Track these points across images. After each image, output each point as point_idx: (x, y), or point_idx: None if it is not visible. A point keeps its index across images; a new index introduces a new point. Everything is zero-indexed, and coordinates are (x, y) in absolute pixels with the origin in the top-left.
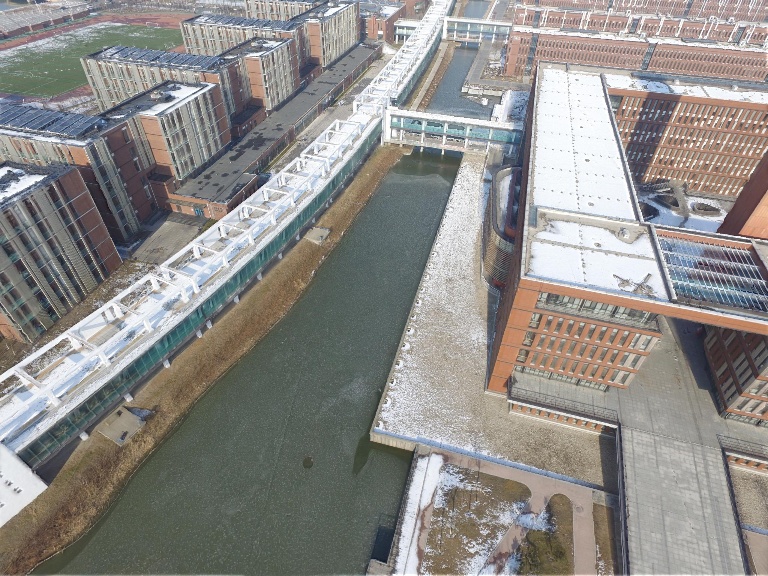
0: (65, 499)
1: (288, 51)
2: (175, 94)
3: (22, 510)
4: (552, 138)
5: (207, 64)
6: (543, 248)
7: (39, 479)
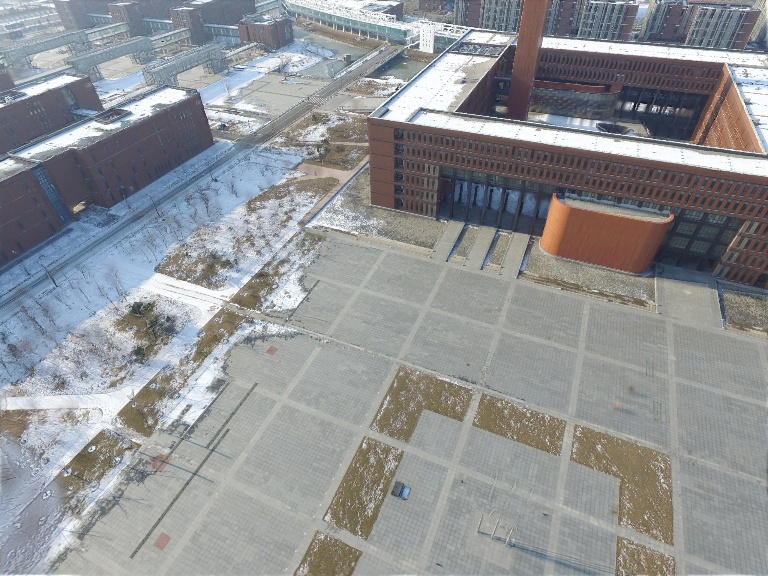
0: (430, 56)
1: (741, 17)
2: (619, 2)
3: (427, 52)
4: (602, 44)
5: (668, 1)
6: (490, 34)
7: (433, 48)
